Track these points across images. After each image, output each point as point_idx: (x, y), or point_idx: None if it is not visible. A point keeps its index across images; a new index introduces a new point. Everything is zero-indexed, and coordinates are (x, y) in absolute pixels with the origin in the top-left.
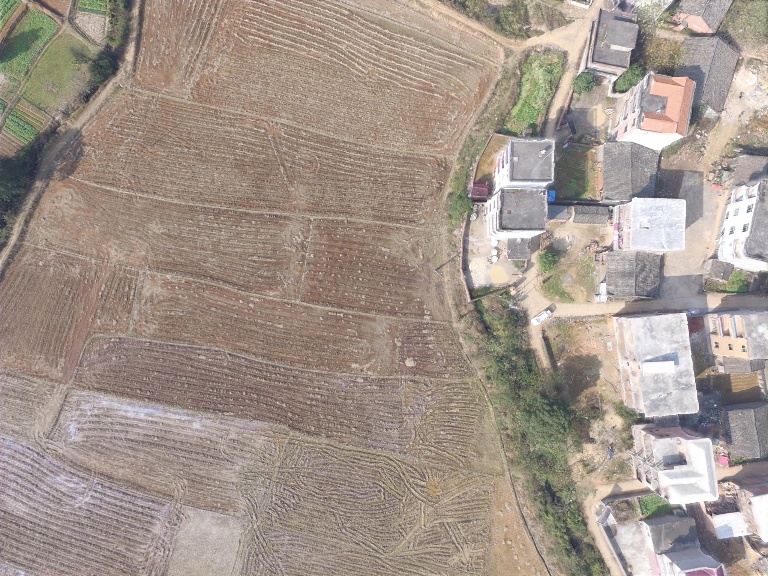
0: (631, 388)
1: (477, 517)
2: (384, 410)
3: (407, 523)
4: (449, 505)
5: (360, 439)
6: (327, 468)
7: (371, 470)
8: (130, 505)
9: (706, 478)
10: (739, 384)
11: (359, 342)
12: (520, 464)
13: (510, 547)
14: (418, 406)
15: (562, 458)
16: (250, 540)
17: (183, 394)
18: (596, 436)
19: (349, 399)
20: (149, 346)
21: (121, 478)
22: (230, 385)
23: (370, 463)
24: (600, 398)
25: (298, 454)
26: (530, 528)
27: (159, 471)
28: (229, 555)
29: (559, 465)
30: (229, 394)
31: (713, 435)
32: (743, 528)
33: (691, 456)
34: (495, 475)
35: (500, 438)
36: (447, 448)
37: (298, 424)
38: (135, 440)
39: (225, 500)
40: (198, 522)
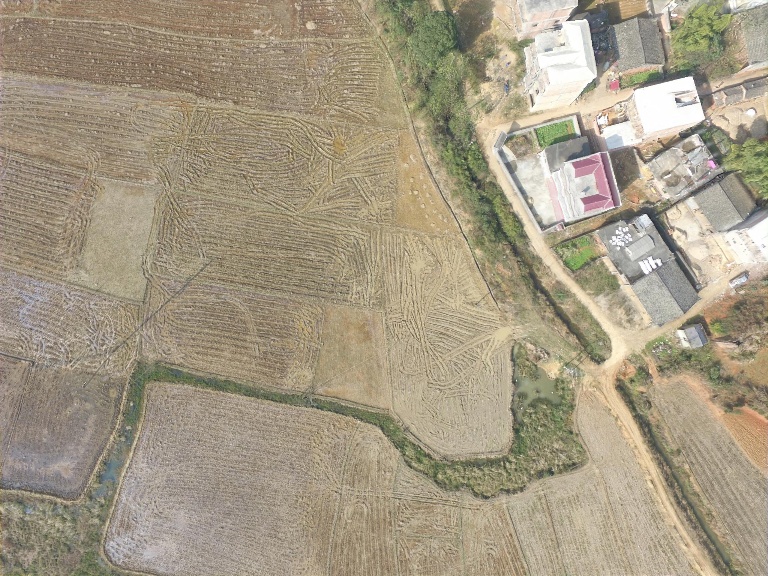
0: (517, 4)
1: (384, 170)
2: (288, 73)
3: (316, 181)
4: (356, 161)
5: (266, 103)
6: (235, 133)
7: (278, 132)
8: (46, 180)
9: (583, 53)
10: (628, 11)
11: (260, 9)
12: (421, 112)
13: (417, 197)
14: (321, 67)
15: (460, 97)
16: (164, 206)
17: (90, 69)
18: (492, 74)
19: (253, 65)
20: (54, 24)
21: (35, 154)
22: (136, 57)
23: (277, 125)
24: (495, 40)
25: (206, 121)
26: (435, 176)
27: (72, 145)
28: (145, 222)
29: (458, 105)
30: (135, 66)
31: (604, 62)
32: (632, 136)
33: (569, 37)
34: (399, 129)
35: (402, 92)
36: (351, 106)
37: (204, 91)
38: (46, 117)
39: (138, 170)
40: (113, 193)
